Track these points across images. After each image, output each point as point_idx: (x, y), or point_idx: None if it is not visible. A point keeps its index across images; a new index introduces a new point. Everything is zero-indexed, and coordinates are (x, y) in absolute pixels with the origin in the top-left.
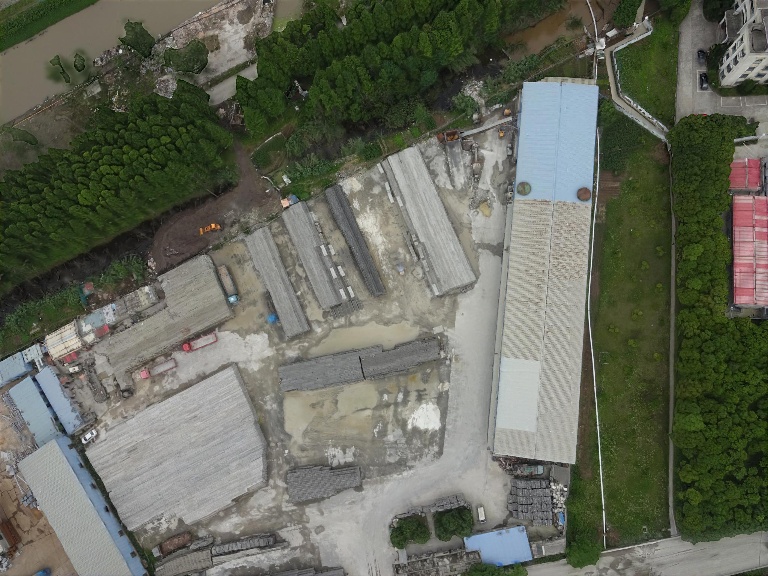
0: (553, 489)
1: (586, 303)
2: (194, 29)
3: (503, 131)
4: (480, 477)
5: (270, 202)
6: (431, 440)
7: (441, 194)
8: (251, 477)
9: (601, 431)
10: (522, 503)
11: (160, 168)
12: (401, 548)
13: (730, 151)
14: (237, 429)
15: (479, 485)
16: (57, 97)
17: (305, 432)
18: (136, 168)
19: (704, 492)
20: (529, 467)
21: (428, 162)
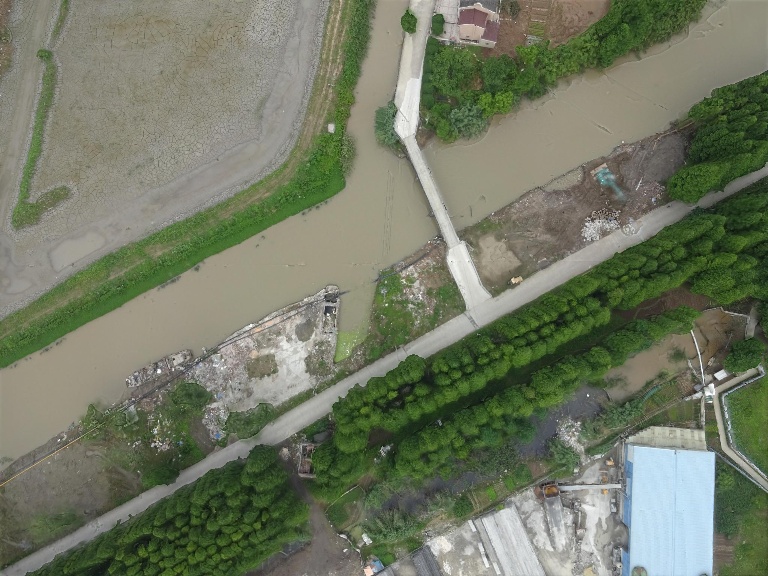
0: None
1: None
2: (246, 346)
3: (607, 489)
4: None
5: (349, 564)
6: None
7: (541, 557)
8: None
9: None
10: None
11: (231, 563)
12: None
13: None
14: None
15: None
16: (85, 425)
17: None
18: (204, 569)
19: None
20: None
21: (525, 519)
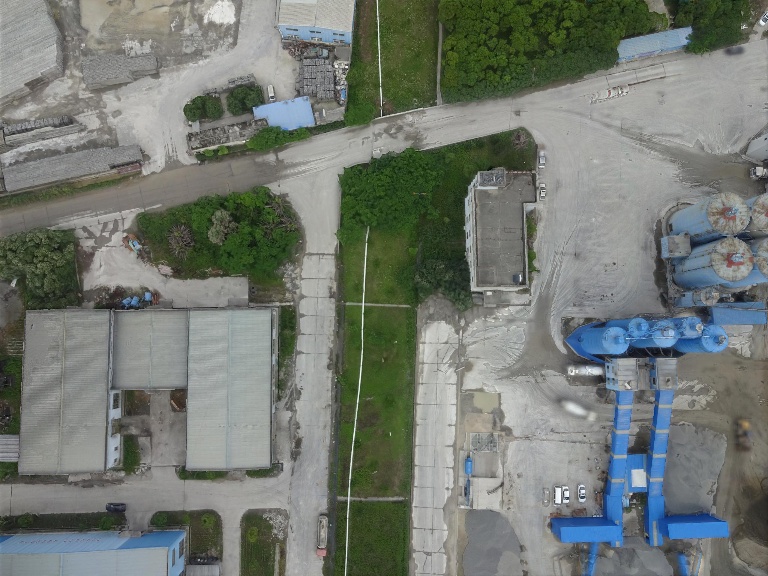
0: (336, 68)
1: None
2: None
3: None
4: (271, 63)
5: None
6: (226, 33)
7: None
8: (44, 62)
9: (380, 21)
10: (307, 77)
11: None
12: (193, 117)
13: None
14: (29, 18)
15: (270, 70)
16: None
17: (102, 27)
18: None
19: (460, 52)
20: (314, 48)
21: None
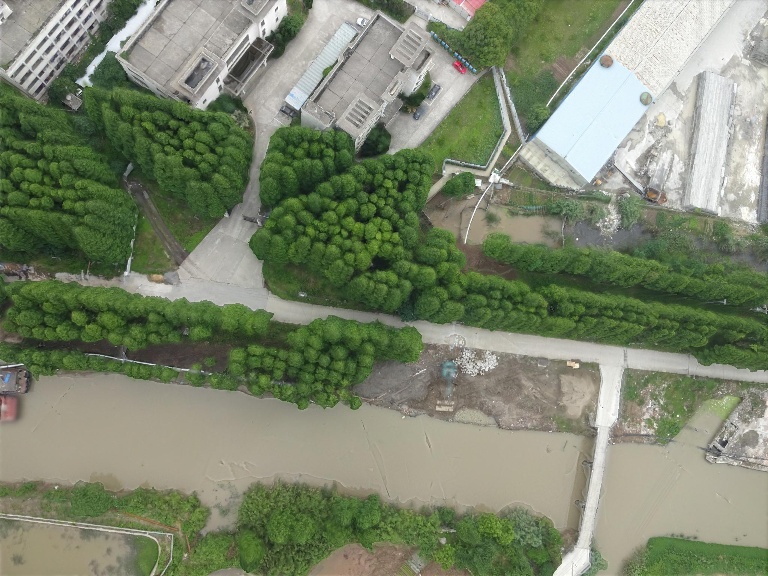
0: None
1: (635, 2)
2: None
3: None
4: None
5: None
6: None
7: (686, 157)
8: None
9: None
10: None
11: None
12: None
13: (492, 5)
14: None
15: None
16: None
17: None
18: None
19: None
20: None
21: (681, 189)
